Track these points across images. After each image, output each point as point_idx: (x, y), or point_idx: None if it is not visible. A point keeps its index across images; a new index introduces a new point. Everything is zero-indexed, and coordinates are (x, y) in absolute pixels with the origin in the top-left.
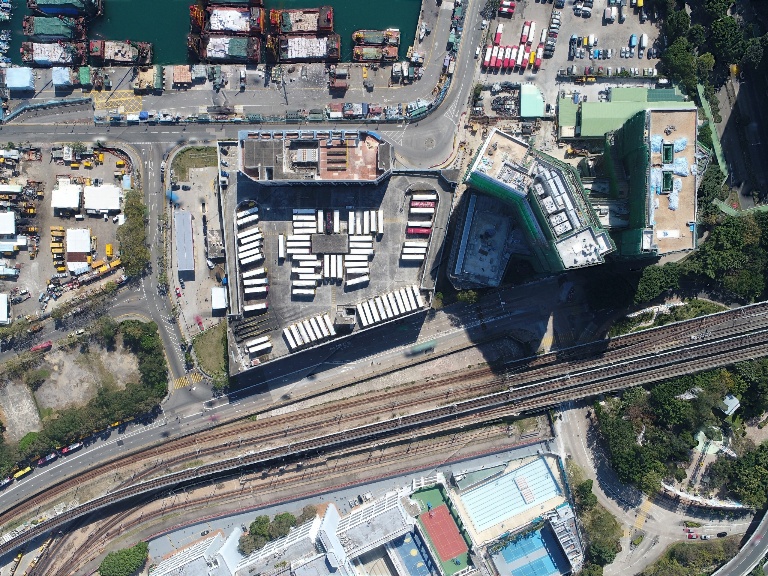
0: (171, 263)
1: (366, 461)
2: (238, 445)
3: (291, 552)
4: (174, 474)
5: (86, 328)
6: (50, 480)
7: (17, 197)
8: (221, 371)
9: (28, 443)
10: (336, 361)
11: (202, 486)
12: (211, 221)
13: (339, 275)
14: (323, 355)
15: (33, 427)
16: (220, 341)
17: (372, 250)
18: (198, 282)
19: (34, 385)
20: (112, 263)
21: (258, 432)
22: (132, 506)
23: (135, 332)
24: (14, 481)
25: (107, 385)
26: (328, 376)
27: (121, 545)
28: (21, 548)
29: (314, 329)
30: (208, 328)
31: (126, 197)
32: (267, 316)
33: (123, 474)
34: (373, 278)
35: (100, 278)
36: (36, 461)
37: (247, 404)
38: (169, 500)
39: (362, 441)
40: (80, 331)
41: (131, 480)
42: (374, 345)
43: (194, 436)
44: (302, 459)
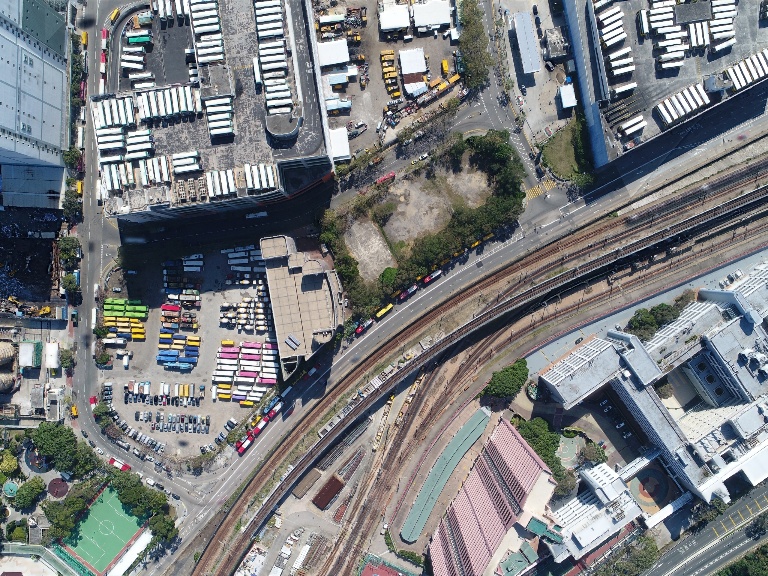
0: (508, 72)
1: (731, 239)
2: (603, 244)
3: (699, 325)
4: (552, 279)
5: (430, 152)
6: (411, 316)
7: (340, 26)
8: (574, 174)
9: (393, 275)
10: (688, 145)
11: (570, 293)
12: (544, 23)
13: (707, 42)
14: (674, 141)
15: (386, 264)
16: (569, 143)
17: (736, 12)
18: (539, 87)
19: (381, 220)
20: (451, 79)
21: (622, 227)
22: (501, 327)
23: (497, 138)
24: (373, 323)
25: (458, 207)
26: (682, 161)
27: (494, 369)
28: (391, 390)
29: (688, 100)
30: (555, 132)
31: (460, 7)
32: (634, 98)
33: (487, 296)
34: (735, 43)
35: (437, 98)
36: (394, 298)
37: (604, 203)
38: (538, 314)
39: (729, 217)
40: (425, 155)
41: (496, 300)
42: (723, 123)
43: (556, 243)
44: (677, 243)
